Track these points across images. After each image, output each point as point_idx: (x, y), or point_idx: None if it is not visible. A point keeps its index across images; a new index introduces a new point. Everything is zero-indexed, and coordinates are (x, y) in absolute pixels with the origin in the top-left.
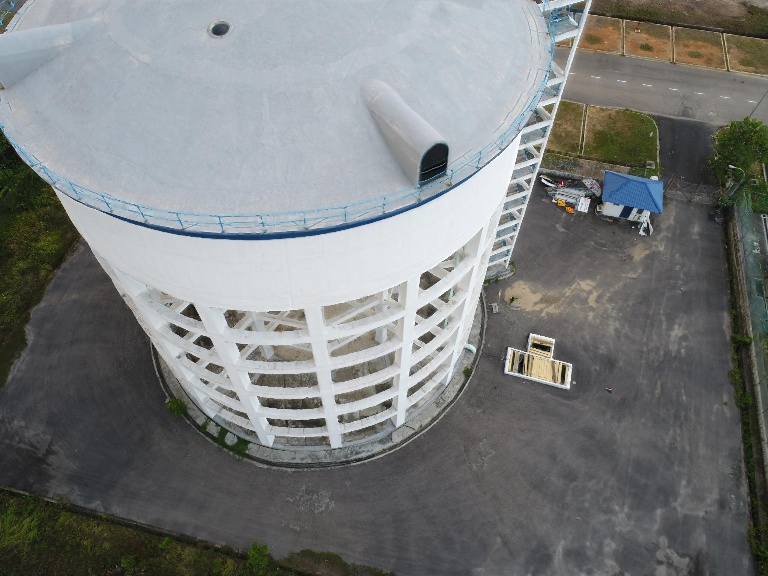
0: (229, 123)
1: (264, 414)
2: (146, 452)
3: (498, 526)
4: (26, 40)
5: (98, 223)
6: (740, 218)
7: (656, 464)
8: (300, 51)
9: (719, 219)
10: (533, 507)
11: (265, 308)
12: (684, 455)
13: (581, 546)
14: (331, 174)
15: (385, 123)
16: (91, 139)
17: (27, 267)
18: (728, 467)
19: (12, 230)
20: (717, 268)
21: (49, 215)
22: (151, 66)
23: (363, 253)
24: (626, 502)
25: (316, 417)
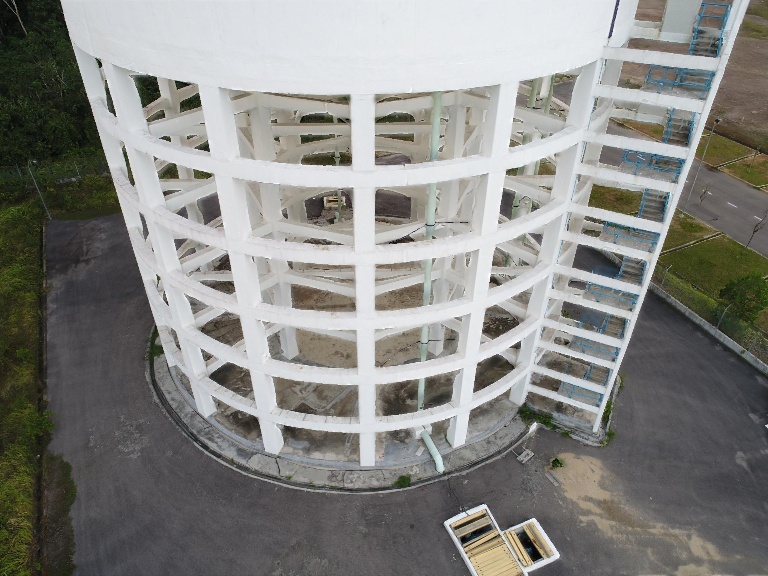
0: None
1: None
2: (117, 303)
3: None
4: None
5: None
6: None
7: None
8: None
9: None
10: None
11: None
12: None
13: None
14: None
15: None
16: None
17: None
18: None
19: None
20: None
21: None
22: None
23: None
24: None
25: None
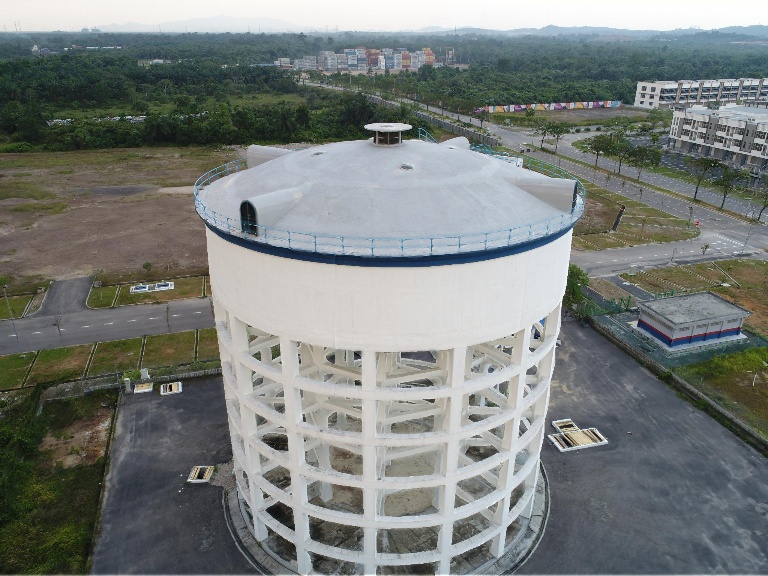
0: (458, 201)
1: (461, 513)
2: None
3: (658, 548)
4: (277, 197)
5: (387, 293)
6: (599, 318)
7: (698, 460)
8: (460, 168)
9: (587, 325)
10: (664, 524)
11: (505, 332)
12: (706, 448)
13: (716, 531)
14: (530, 213)
15: (535, 186)
16: (375, 229)
17: (52, 567)
18: (733, 443)
19: (2, 546)
20: (612, 348)
21: (39, 517)
22: (383, 188)
23: (554, 267)
24: (708, 490)
25: (499, 498)
